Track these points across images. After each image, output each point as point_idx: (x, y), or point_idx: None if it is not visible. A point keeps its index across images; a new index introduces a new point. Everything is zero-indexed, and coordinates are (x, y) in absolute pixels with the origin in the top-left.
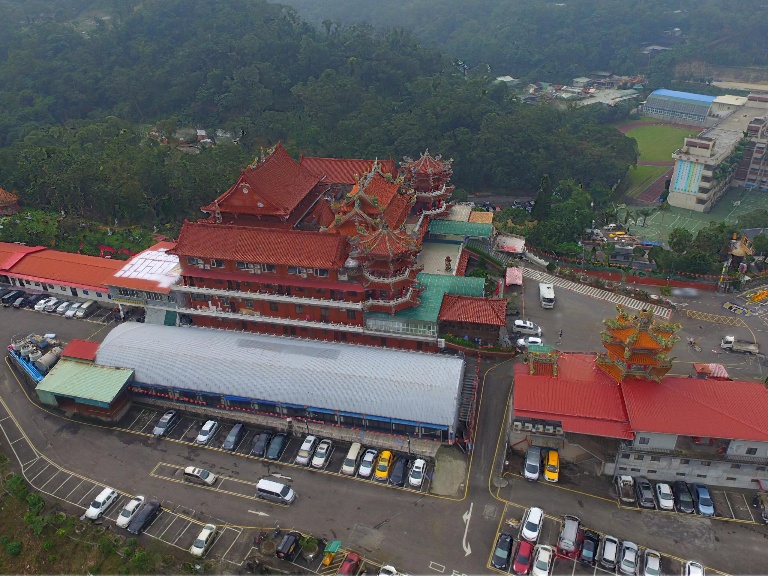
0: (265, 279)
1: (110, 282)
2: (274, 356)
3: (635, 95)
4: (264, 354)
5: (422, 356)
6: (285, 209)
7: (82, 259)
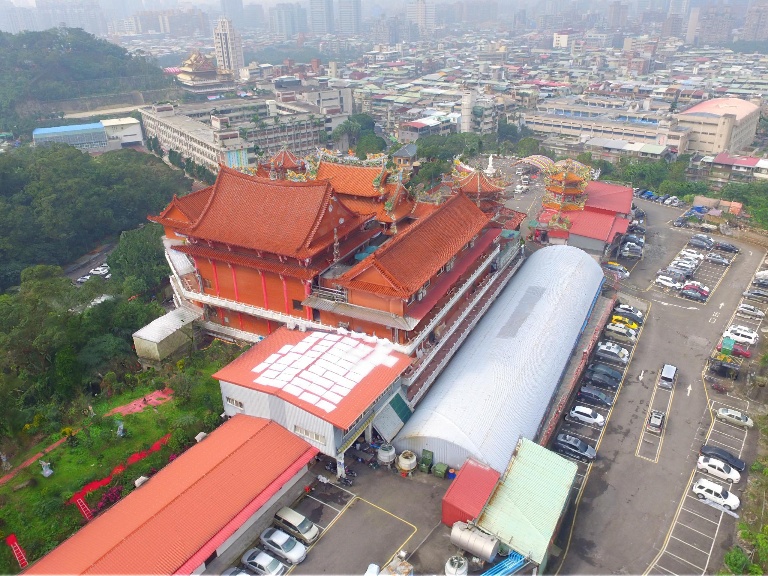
0: (459, 269)
1: (349, 416)
2: (536, 318)
3: (5, 143)
4: (532, 323)
5: (541, 258)
6: (360, 214)
7: (127, 516)
